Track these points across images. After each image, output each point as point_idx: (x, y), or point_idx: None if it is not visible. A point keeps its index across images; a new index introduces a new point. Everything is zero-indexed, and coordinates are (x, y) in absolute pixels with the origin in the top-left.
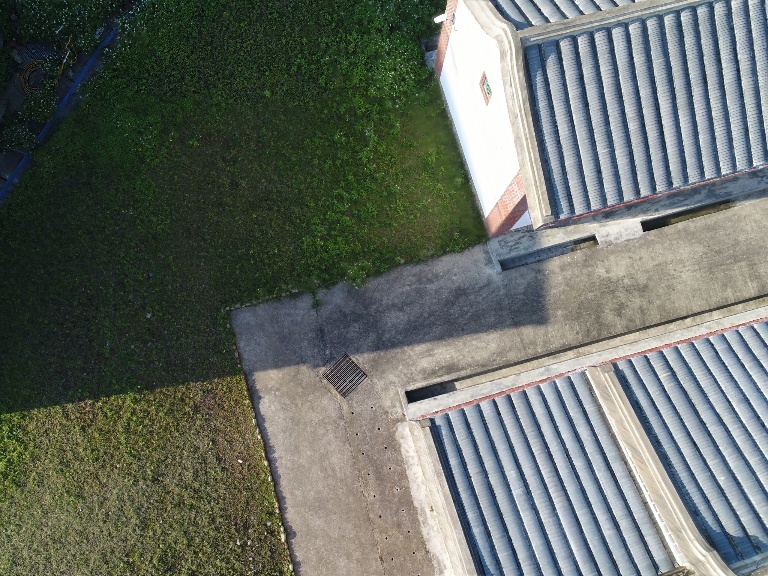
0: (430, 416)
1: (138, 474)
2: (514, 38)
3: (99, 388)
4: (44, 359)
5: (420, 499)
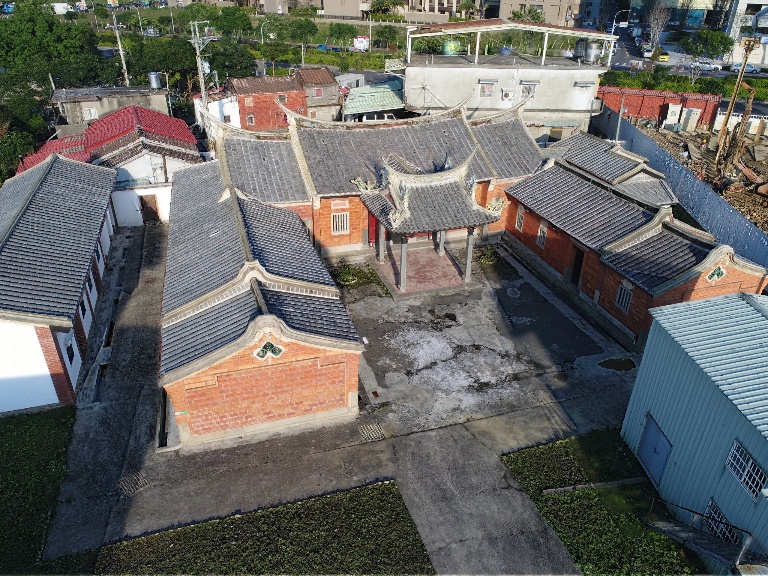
0: None
1: None
2: None
3: None
4: None
5: (233, 443)
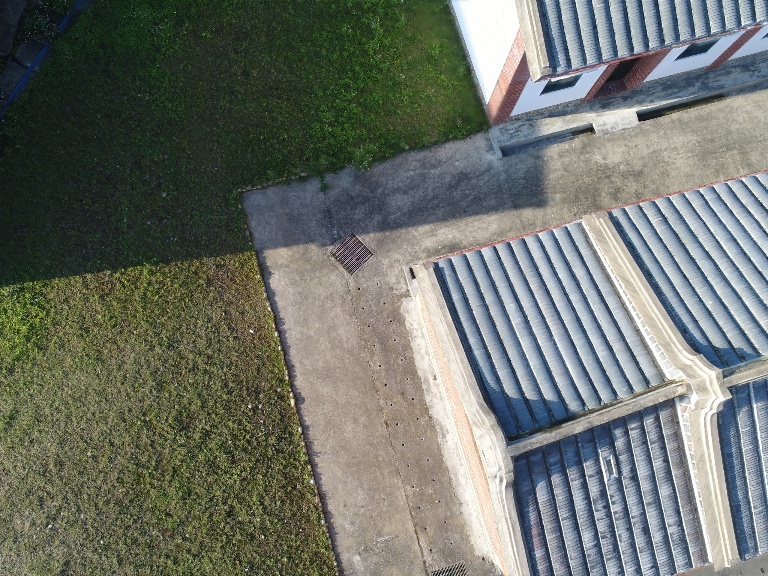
0: (434, 261)
1: (154, 340)
2: None
3: (117, 260)
4: (64, 233)
5: (424, 369)
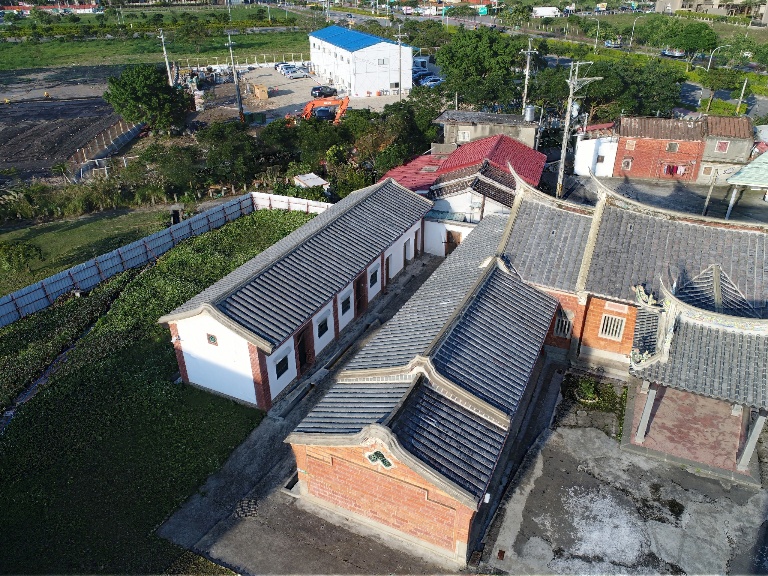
0: None
1: None
2: (209, 304)
3: None
4: None
5: (337, 521)
